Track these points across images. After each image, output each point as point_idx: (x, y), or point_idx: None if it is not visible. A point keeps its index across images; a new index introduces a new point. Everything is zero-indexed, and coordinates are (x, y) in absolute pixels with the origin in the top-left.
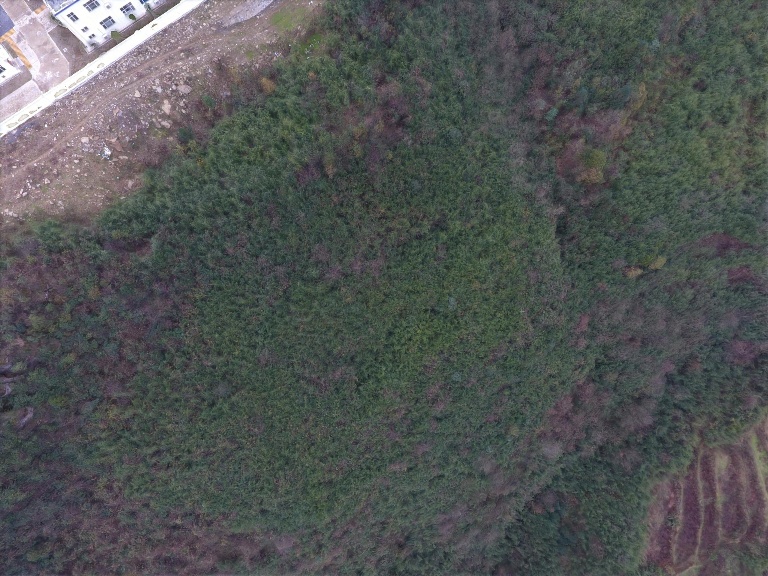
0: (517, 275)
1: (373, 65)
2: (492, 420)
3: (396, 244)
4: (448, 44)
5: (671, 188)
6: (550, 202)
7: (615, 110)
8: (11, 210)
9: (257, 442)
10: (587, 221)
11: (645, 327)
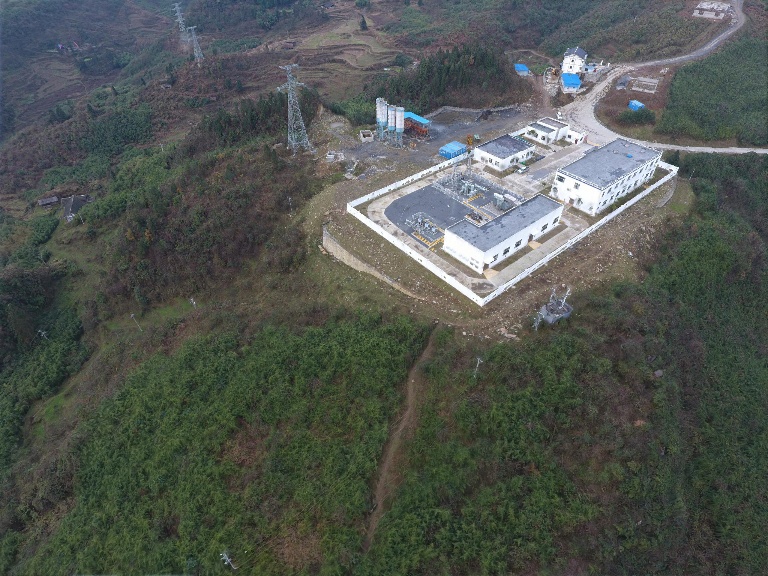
0: None
1: None
2: None
3: None
4: None
5: None
6: None
7: None
8: None
9: None
10: None
11: None
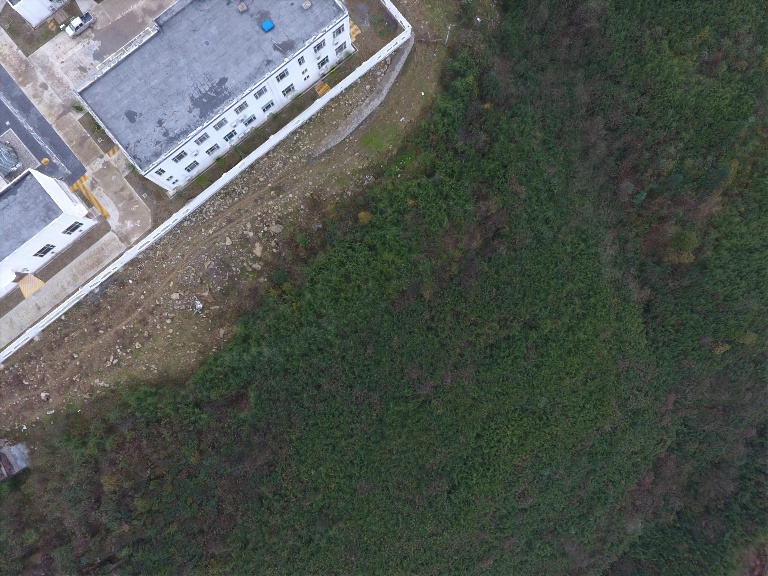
0: (607, 366)
1: (470, 180)
2: (575, 502)
3: (483, 346)
4: (538, 140)
5: (763, 264)
6: (635, 283)
7: (707, 190)
8: (102, 380)
9: (353, 569)
10: (673, 300)
11: (728, 397)
